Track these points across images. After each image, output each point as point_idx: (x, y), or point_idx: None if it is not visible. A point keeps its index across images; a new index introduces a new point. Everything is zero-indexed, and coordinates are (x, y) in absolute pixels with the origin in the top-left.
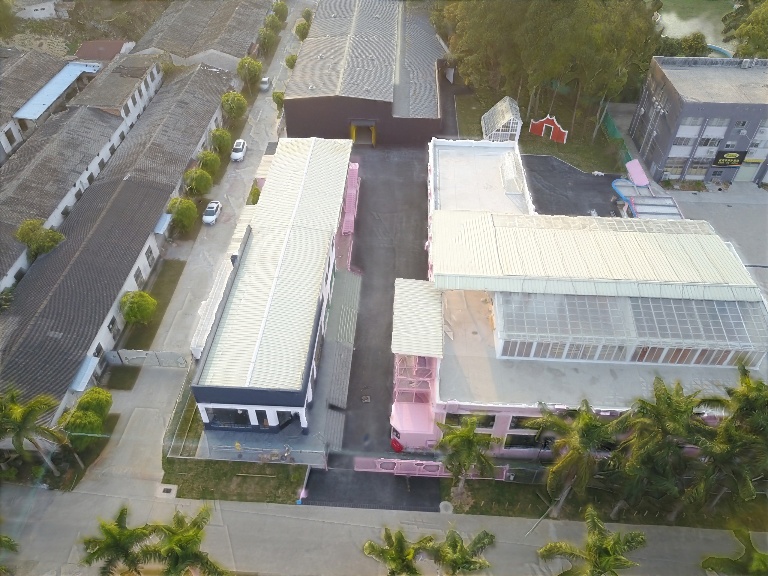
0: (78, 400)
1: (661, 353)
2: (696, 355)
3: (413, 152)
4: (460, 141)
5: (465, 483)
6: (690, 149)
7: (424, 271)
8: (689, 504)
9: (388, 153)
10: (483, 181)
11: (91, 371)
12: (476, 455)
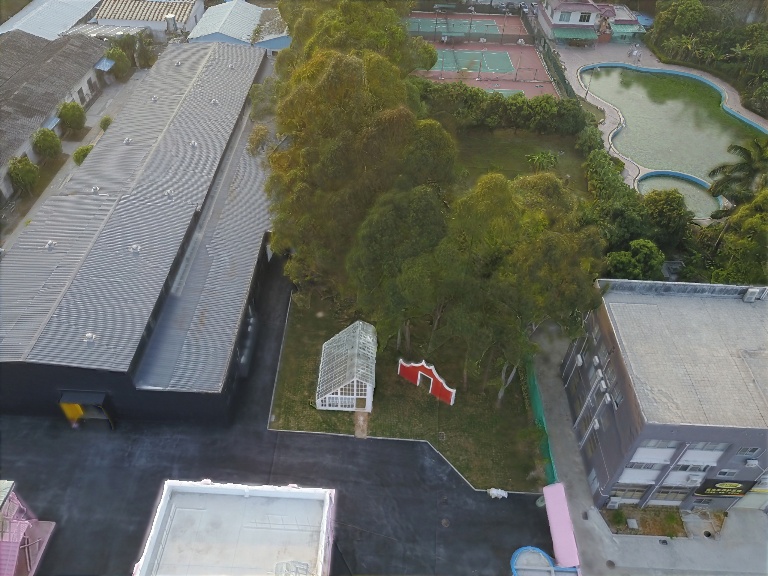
0: None
1: None
2: None
3: (180, 440)
4: (221, 487)
5: None
6: (656, 473)
7: None
8: None
9: (134, 444)
10: None
11: None
12: None
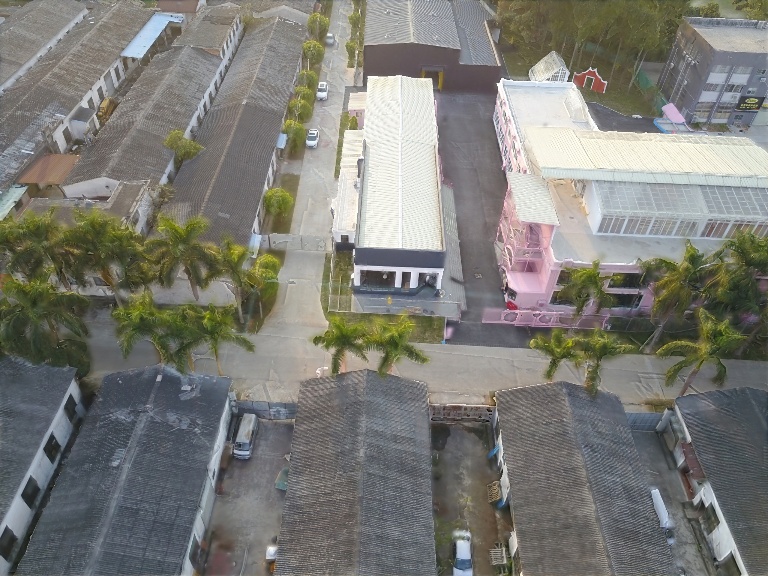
0: (258, 261)
1: (726, 228)
2: (753, 230)
3: (475, 96)
4: (525, 82)
5: None
6: (717, 95)
7: (505, 186)
8: (750, 345)
9: (454, 97)
10: (551, 112)
11: (258, 244)
12: (599, 290)
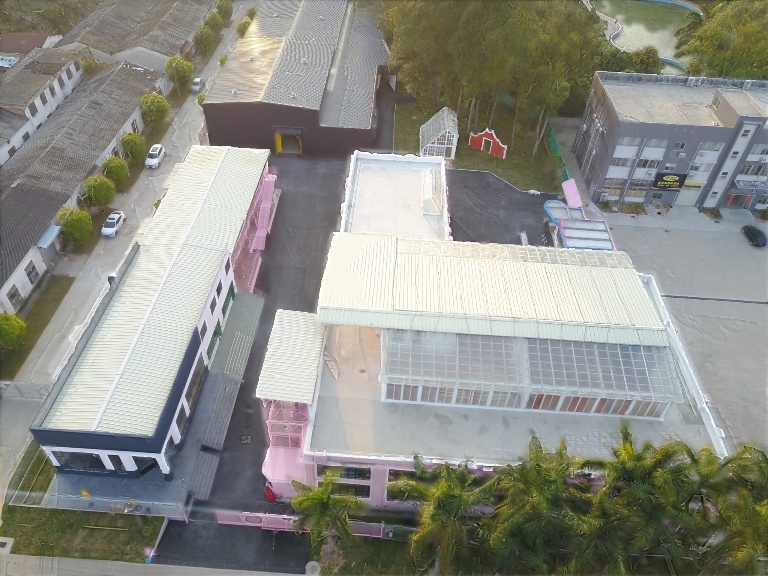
0: None
1: (557, 401)
2: (595, 404)
3: (342, 163)
4: (384, 155)
5: (338, 540)
6: (628, 170)
7: None
8: None
9: (315, 164)
10: (402, 199)
11: None
12: (331, 519)
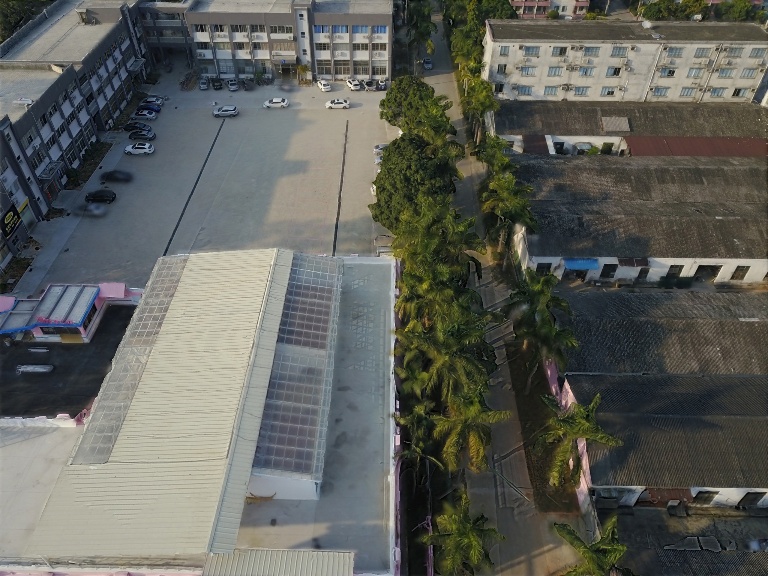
0: None
1: None
2: None
3: None
4: None
5: (437, 573)
6: None
7: None
8: None
9: None
10: None
11: None
12: None
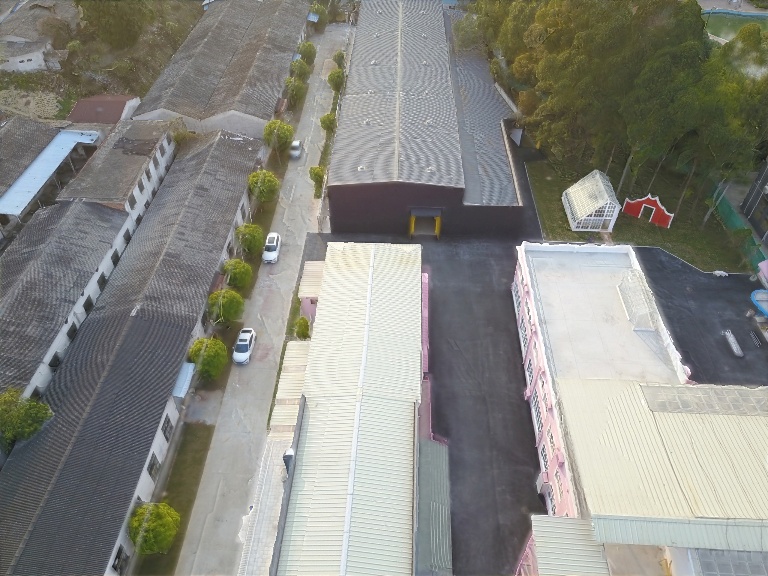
0: None
1: None
2: None
3: (487, 245)
4: (559, 246)
5: None
6: None
7: (529, 435)
8: None
9: (456, 247)
10: (600, 309)
11: None
12: None
